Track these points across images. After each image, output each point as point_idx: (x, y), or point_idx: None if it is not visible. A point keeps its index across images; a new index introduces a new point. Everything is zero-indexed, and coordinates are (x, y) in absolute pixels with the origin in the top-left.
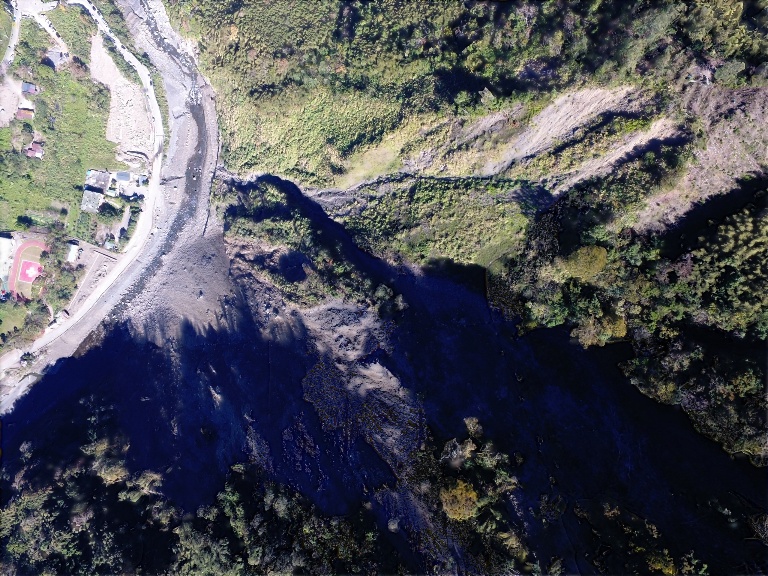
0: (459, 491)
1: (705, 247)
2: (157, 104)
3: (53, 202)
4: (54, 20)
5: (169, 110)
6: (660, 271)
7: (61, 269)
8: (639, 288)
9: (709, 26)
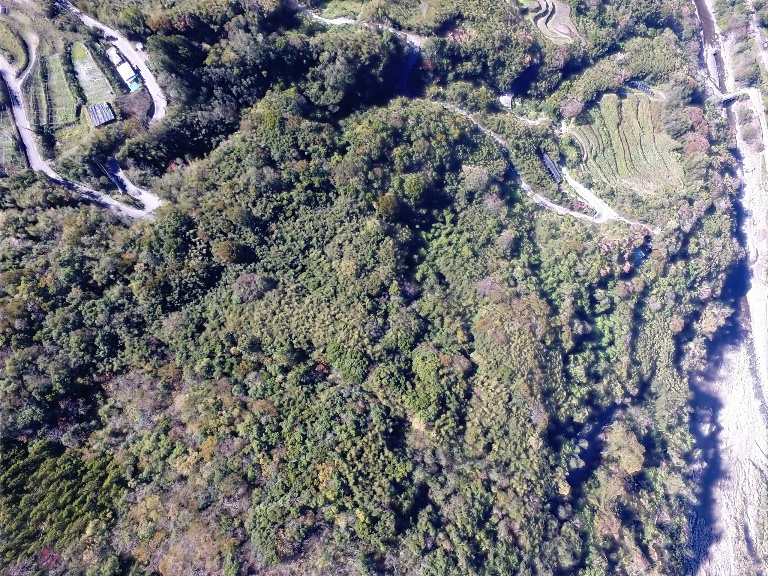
0: None
1: None
2: None
3: None
4: None
5: None
6: None
7: None
8: None
9: None
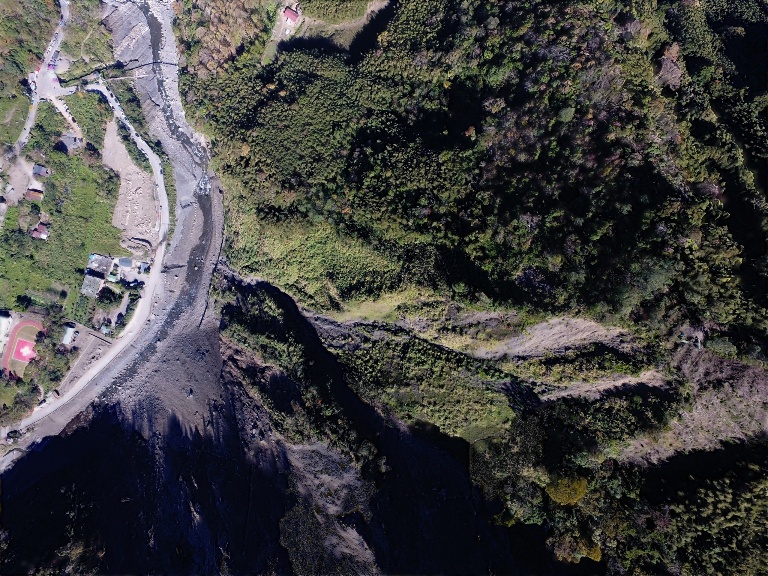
0: None
1: (684, 504)
2: (165, 193)
3: (54, 284)
4: (71, 105)
5: (177, 199)
6: (638, 515)
7: (55, 352)
8: (616, 525)
9: (705, 293)
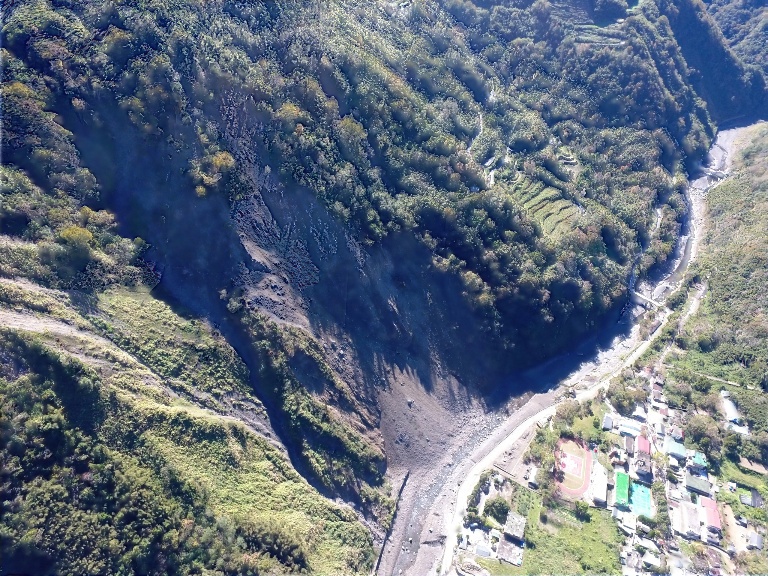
0: (220, 160)
1: (2, 209)
2: None
3: (556, 533)
4: None
5: None
6: None
7: (542, 460)
8: (57, 213)
9: None
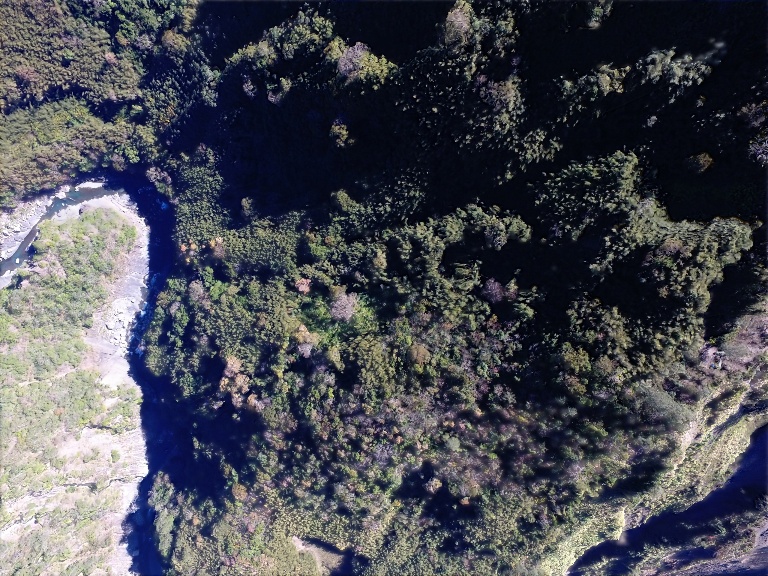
0: None
1: None
2: None
3: None
4: None
5: None
6: None
7: None
8: None
9: None
